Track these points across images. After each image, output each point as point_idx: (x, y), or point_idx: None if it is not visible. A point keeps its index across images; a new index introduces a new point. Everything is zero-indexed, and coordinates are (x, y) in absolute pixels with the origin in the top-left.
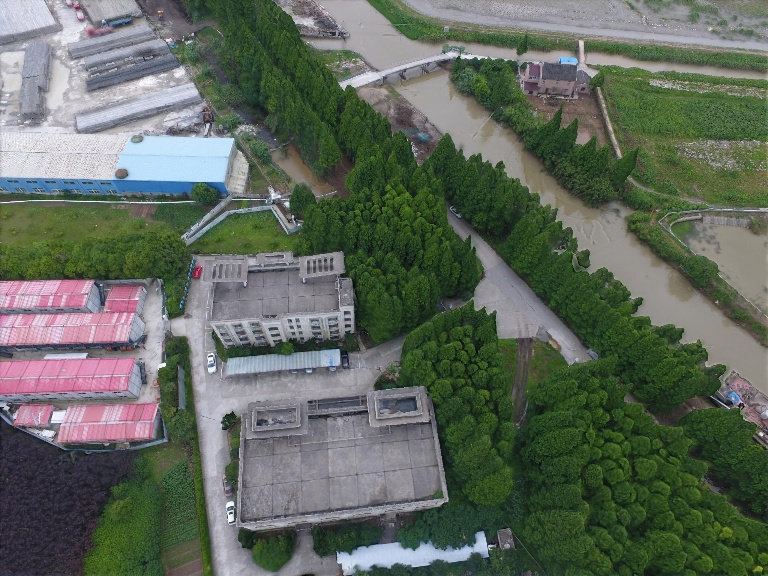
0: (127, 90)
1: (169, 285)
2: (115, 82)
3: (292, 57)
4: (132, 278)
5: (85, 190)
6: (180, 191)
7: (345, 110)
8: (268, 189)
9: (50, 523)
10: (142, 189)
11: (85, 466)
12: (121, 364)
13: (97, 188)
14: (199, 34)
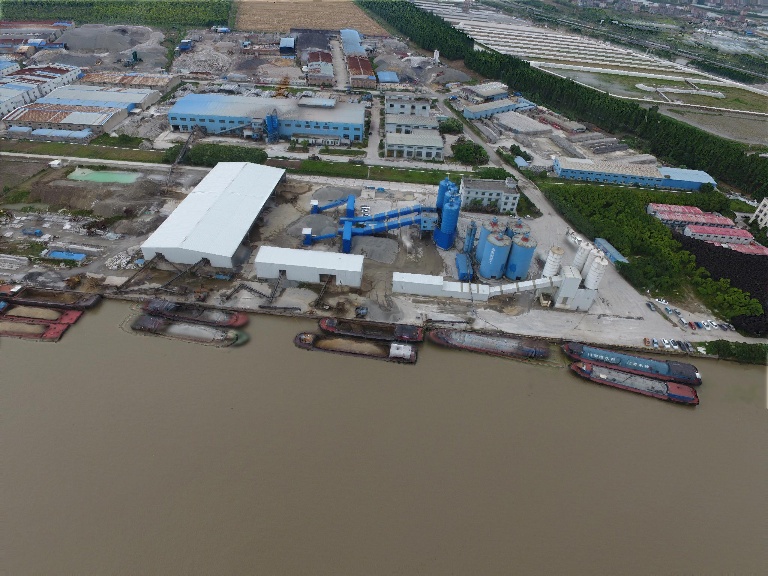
0: (614, 155)
1: (726, 214)
2: (606, 151)
3: (710, 143)
4: (706, 211)
5: (645, 184)
6: (690, 188)
7: (758, 162)
8: (728, 192)
9: (765, 268)
10: (672, 185)
11: (761, 255)
12: (742, 230)
13: (651, 183)
14: (624, 138)
